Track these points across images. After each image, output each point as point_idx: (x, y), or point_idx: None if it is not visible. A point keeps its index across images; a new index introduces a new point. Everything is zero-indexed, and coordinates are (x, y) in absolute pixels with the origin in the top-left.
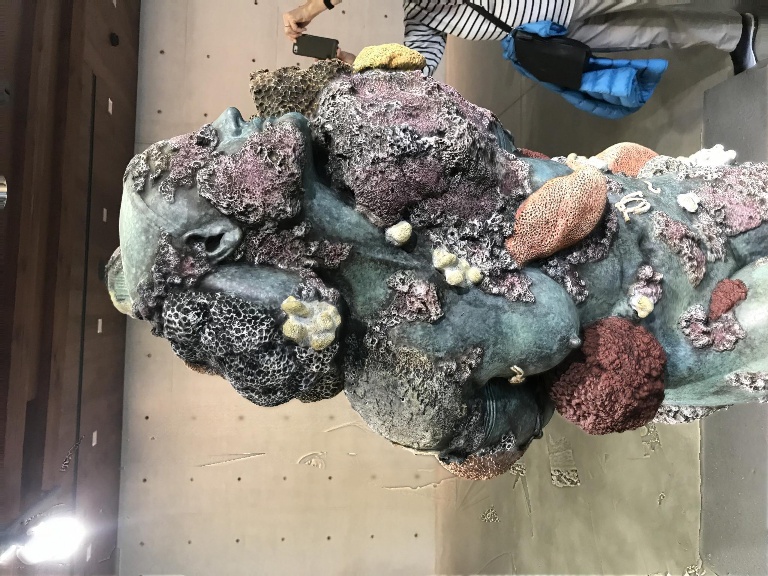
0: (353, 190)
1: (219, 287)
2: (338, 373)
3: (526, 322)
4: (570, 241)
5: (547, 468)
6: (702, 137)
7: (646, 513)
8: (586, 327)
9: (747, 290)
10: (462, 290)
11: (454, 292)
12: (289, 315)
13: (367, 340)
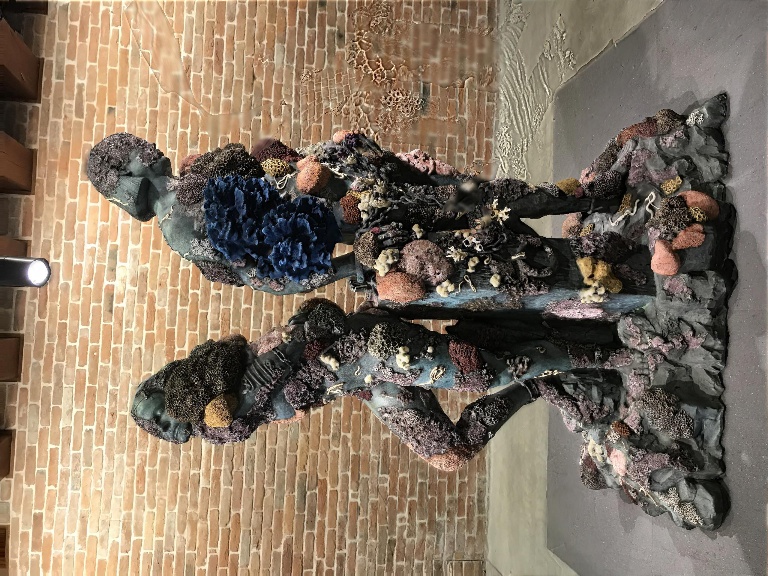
0: None
1: None
2: None
3: None
4: None
5: None
6: None
7: None
8: None
9: (370, 400)
10: None
11: None
12: None
13: None
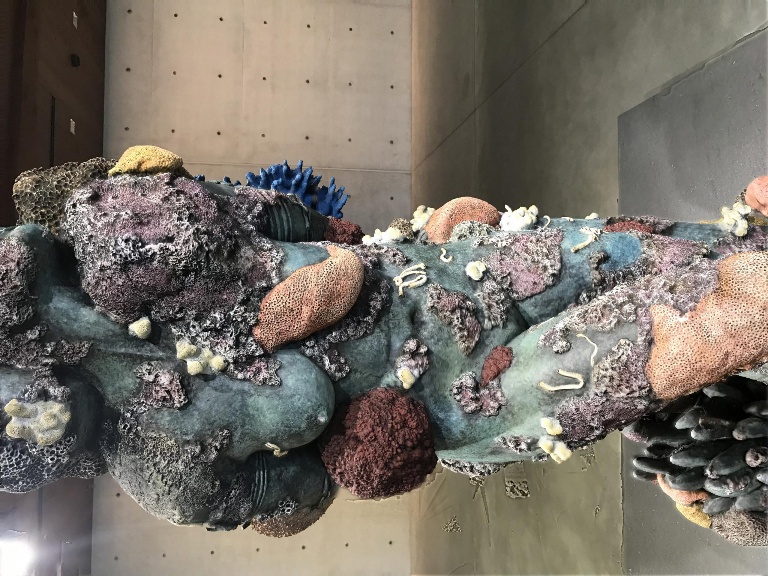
0: (88, 293)
1: None
2: (95, 456)
3: (272, 404)
4: (323, 324)
5: (502, 479)
6: (618, 161)
7: (584, 526)
8: (354, 399)
9: (512, 358)
10: (209, 377)
11: (200, 379)
12: (12, 416)
13: (119, 426)
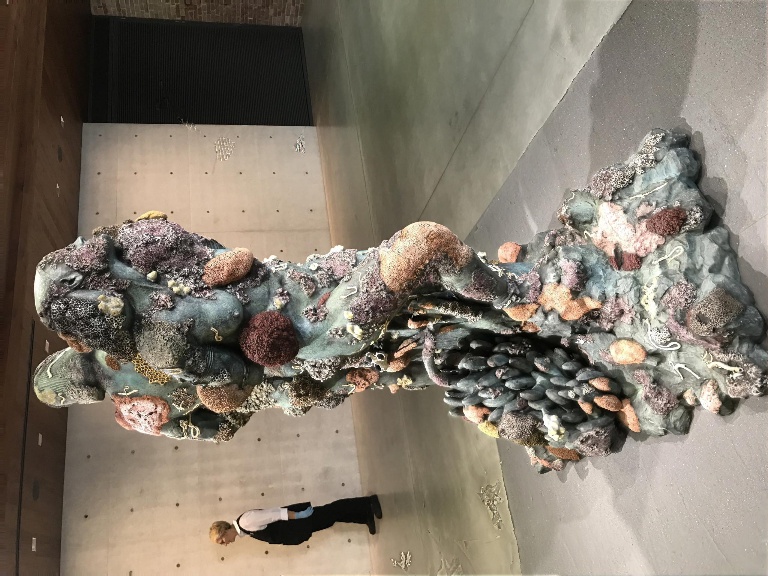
0: (130, 260)
1: (73, 296)
2: (131, 337)
3: (213, 307)
4: (235, 277)
5: None
6: None
7: None
8: None
9: (330, 294)
10: (183, 297)
11: (179, 298)
12: (101, 301)
13: (143, 321)
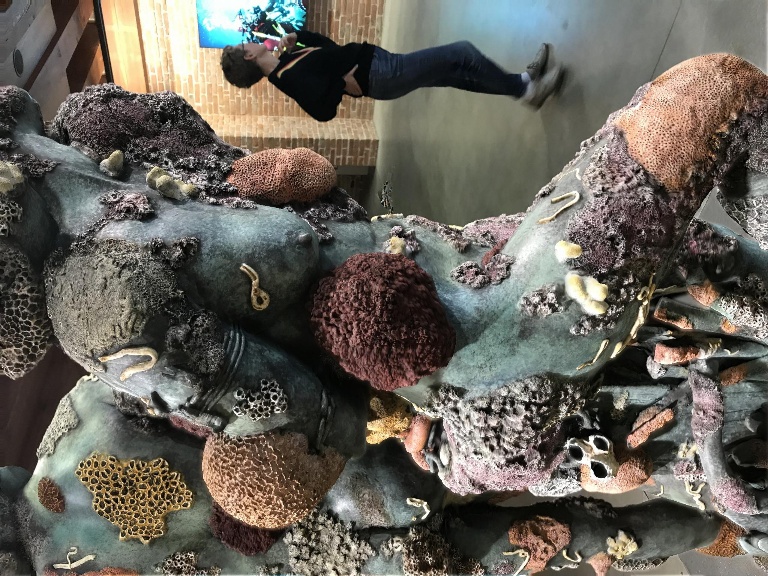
0: (66, 128)
1: None
2: (35, 278)
3: (247, 220)
4: (299, 190)
5: None
6: None
7: None
8: None
9: (507, 238)
10: (178, 203)
11: (169, 203)
12: None
13: (71, 244)
